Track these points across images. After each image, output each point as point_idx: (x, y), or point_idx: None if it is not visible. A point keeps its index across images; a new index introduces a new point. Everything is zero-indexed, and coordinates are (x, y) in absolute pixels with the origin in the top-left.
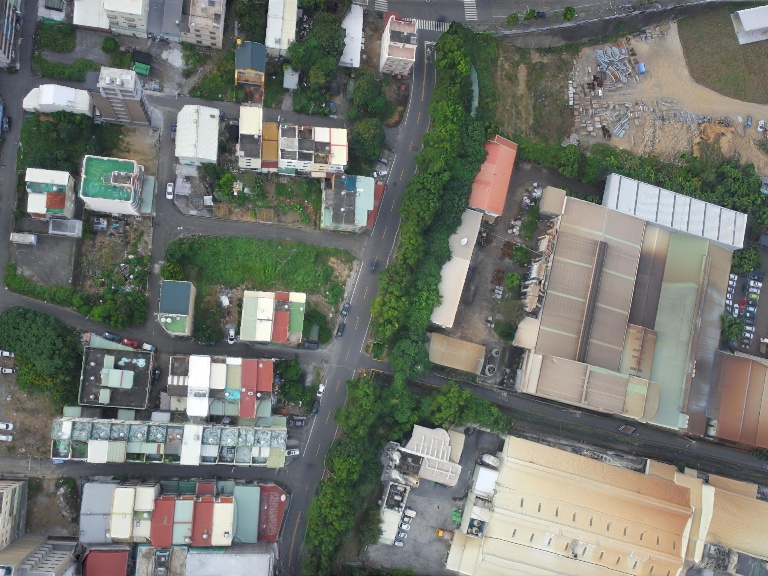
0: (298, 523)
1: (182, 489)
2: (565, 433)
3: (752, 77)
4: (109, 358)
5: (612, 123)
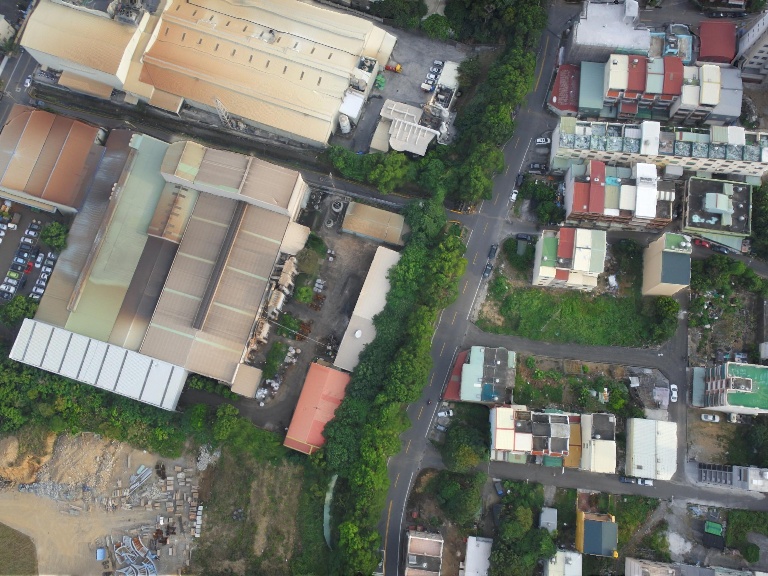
0: (537, 82)
1: (649, 112)
2: (260, 147)
3: None
4: (728, 222)
5: (151, 483)
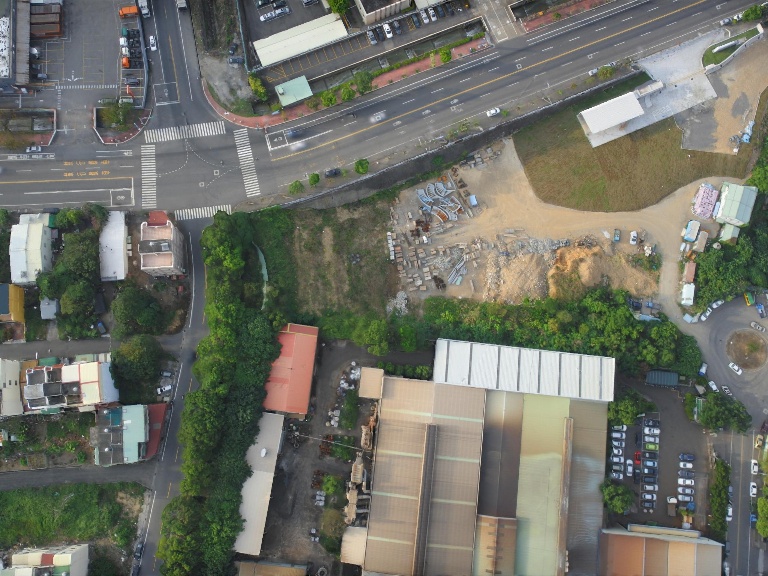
0: None
1: None
2: None
3: (614, 182)
4: None
5: (446, 270)
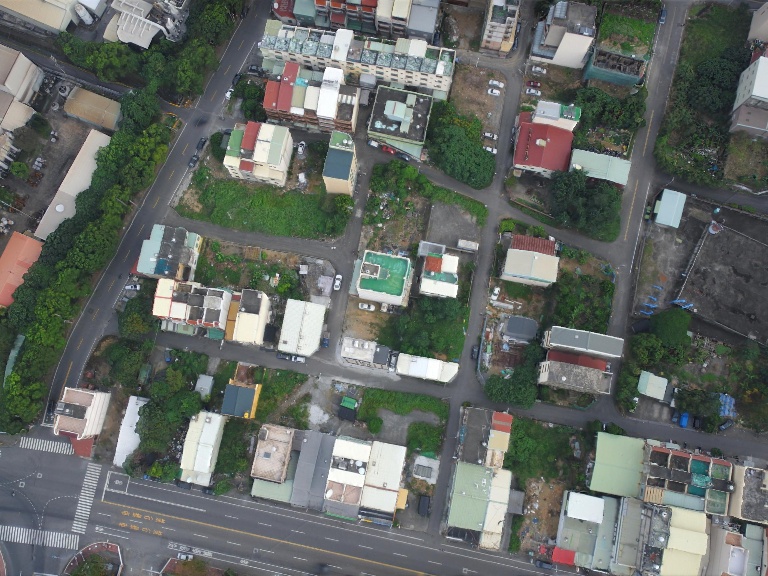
0: None
1: (359, 24)
2: (6, 31)
3: None
4: (404, 129)
5: None
